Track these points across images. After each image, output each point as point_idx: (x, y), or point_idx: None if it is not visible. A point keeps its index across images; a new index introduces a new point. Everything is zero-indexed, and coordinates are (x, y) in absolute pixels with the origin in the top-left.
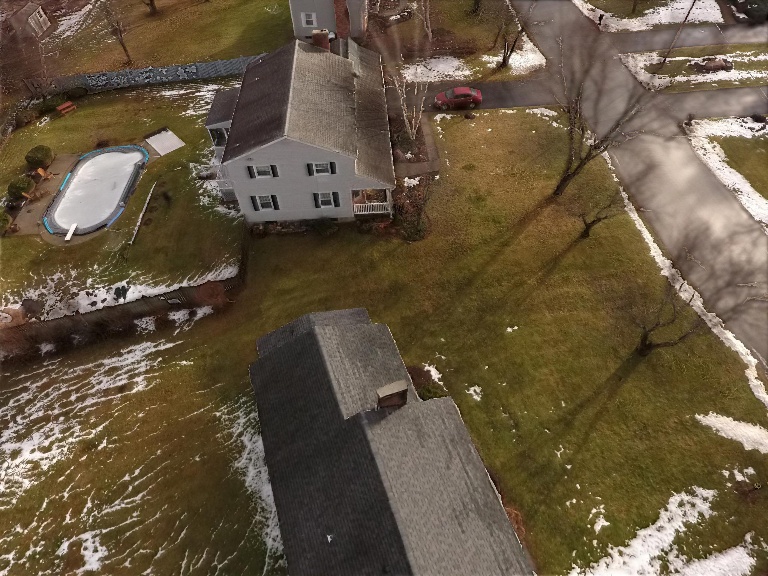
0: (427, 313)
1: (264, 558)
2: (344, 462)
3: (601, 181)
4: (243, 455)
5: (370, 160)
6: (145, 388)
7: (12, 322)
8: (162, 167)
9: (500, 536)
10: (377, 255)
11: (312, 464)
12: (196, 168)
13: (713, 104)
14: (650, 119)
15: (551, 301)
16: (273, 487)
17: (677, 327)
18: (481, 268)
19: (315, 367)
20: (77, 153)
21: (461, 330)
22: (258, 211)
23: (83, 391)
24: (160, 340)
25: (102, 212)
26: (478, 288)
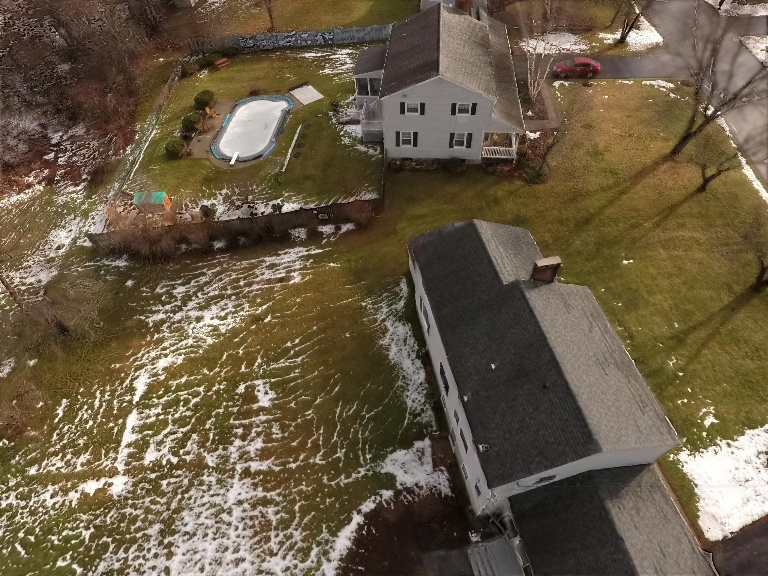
0: (547, 243)
1: (405, 414)
2: (504, 314)
3: (718, 146)
4: (386, 336)
5: (503, 108)
6: (300, 281)
7: (195, 220)
8: (305, 114)
9: (636, 385)
10: (500, 193)
11: (475, 316)
12: (335, 116)
13: None
14: None
15: (666, 242)
16: (440, 332)
17: None
18: (598, 210)
19: (475, 248)
20: (234, 99)
21: (579, 259)
22: (398, 147)
23: (249, 279)
24: (311, 246)
25: (257, 146)
26: (595, 226)
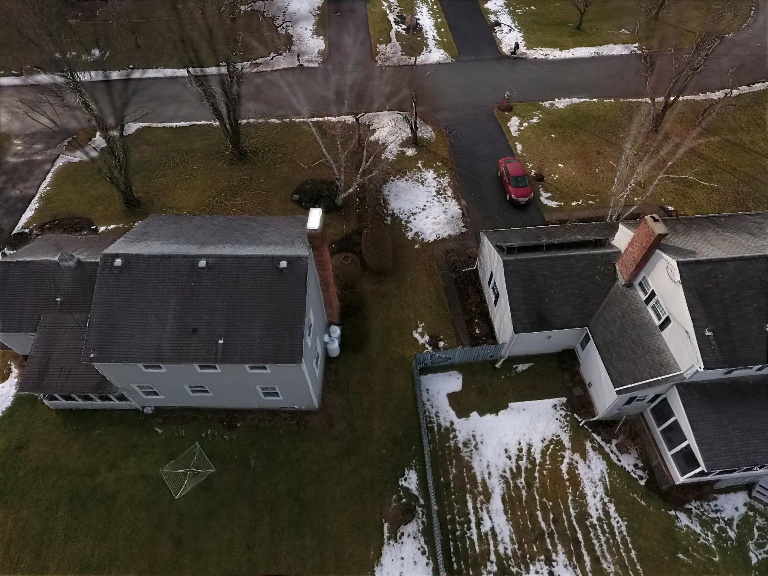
0: None
1: None
2: None
3: (620, 108)
4: None
5: None
6: None
7: None
8: None
9: None
10: None
11: None
12: (765, 541)
13: (475, 37)
14: (508, 69)
15: None
16: None
17: (766, 102)
18: None
19: None
20: None
21: None
22: None
23: None
24: None
25: None
26: None
